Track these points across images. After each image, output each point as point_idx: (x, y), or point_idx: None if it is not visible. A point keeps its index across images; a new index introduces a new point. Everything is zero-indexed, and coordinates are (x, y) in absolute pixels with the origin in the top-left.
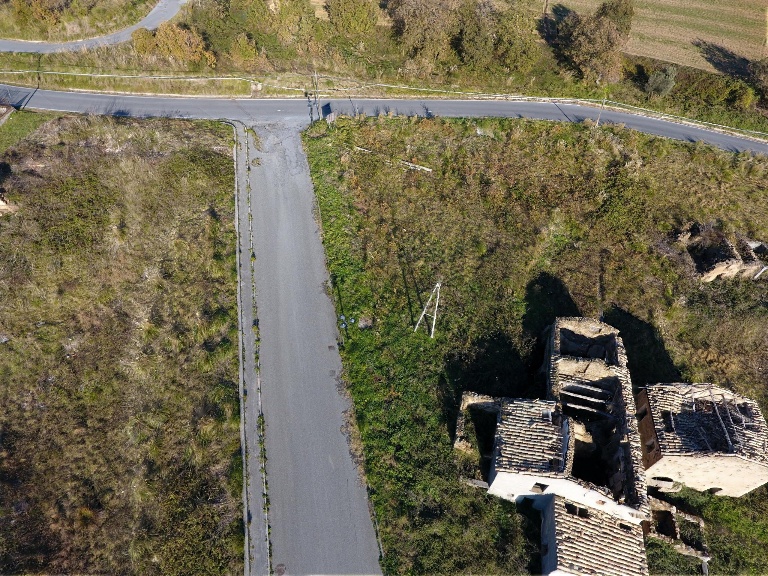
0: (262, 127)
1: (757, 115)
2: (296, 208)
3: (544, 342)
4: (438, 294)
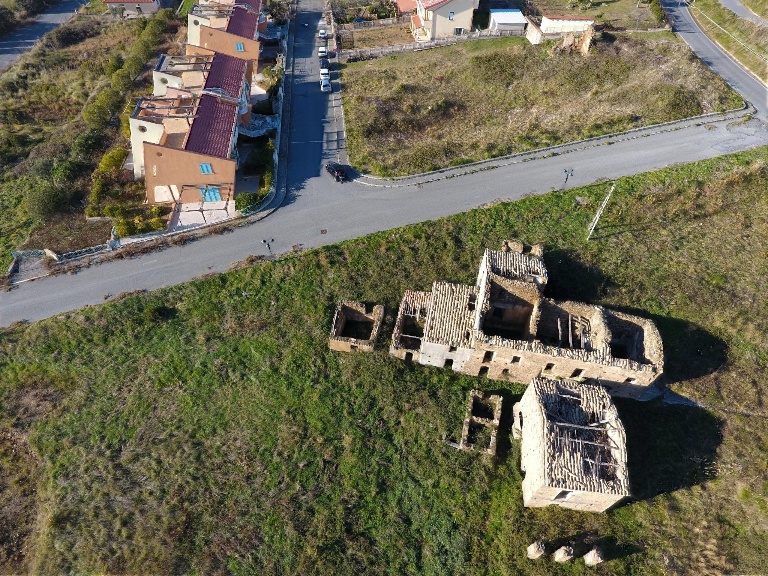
0: (761, 123)
1: None
2: (674, 154)
3: None
4: None
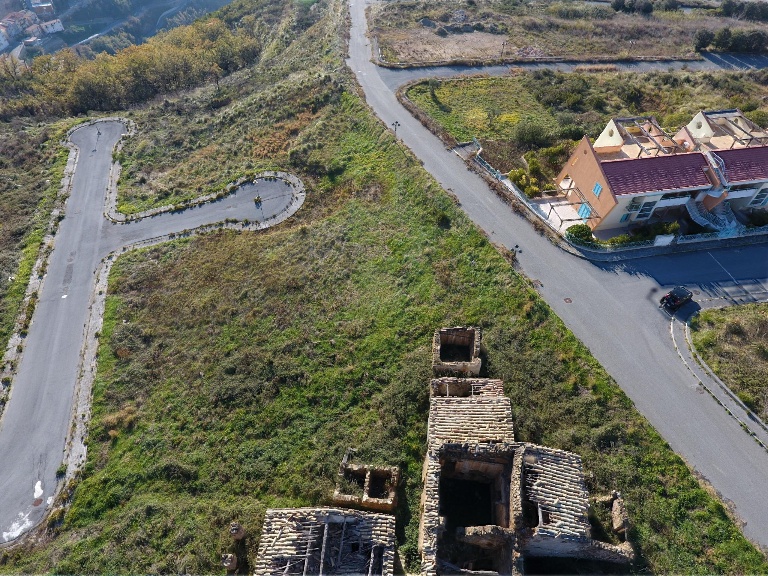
0: None
1: None
2: None
3: None
4: None
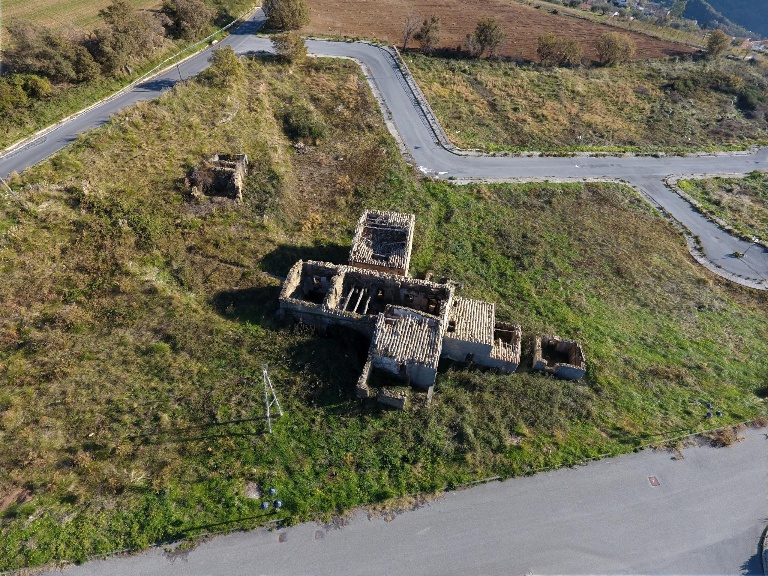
0: None
1: (68, 90)
2: None
3: (293, 320)
4: (268, 378)
